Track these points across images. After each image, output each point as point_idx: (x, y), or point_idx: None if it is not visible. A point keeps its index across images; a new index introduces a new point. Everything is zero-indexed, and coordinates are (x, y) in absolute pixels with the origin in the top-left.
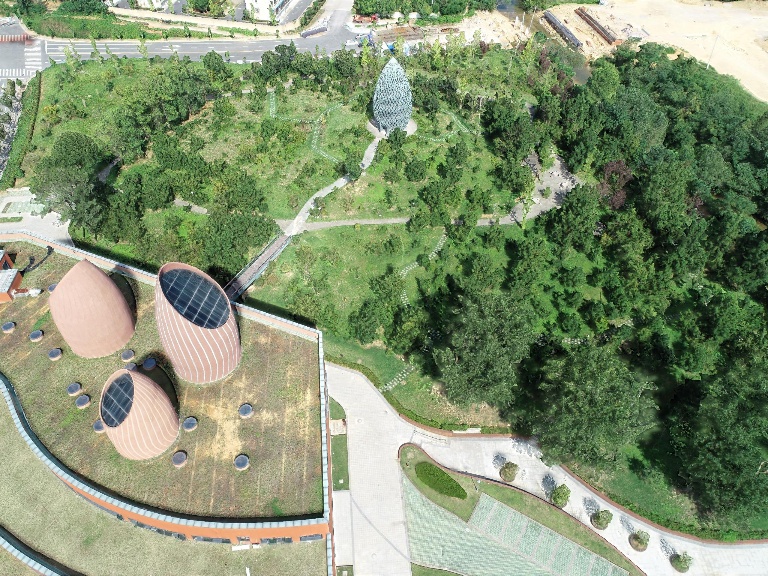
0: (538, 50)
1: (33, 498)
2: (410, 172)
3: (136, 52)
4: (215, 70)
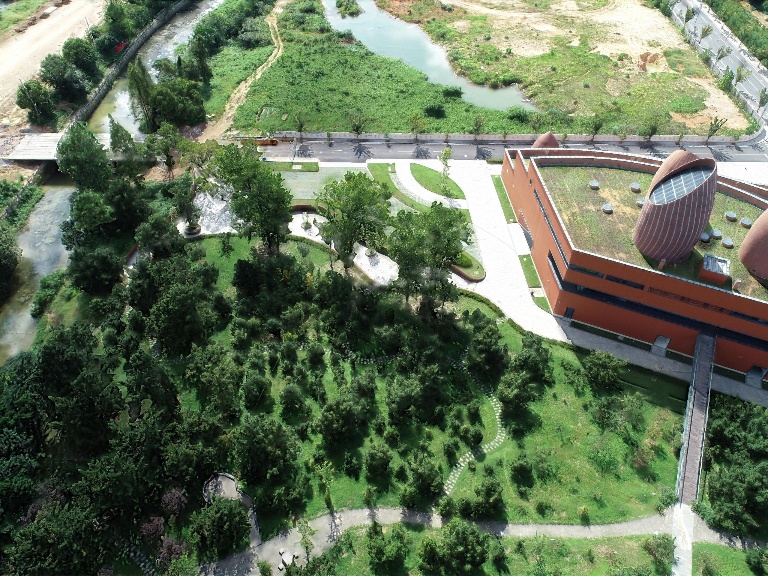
0: None
1: None
2: None
3: None
4: None
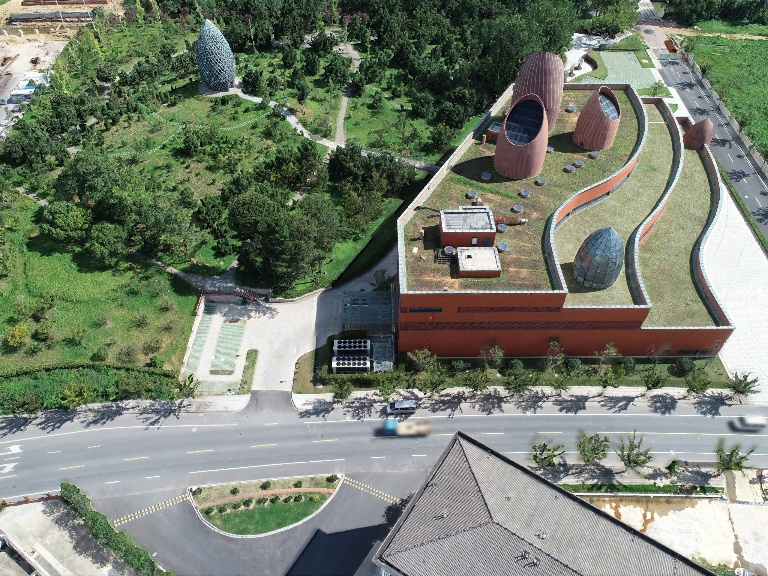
0: (117, 19)
1: (637, 193)
2: None
3: None
4: (5, 191)
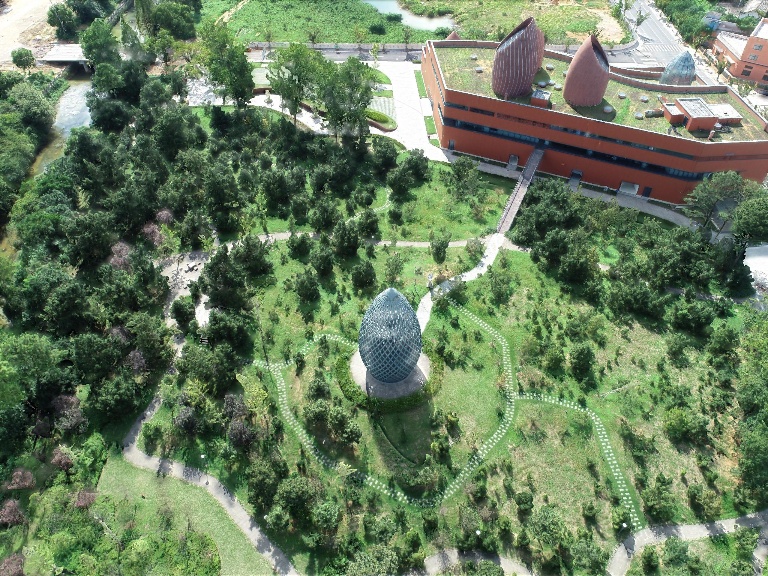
0: None
1: None
2: None
3: None
4: None
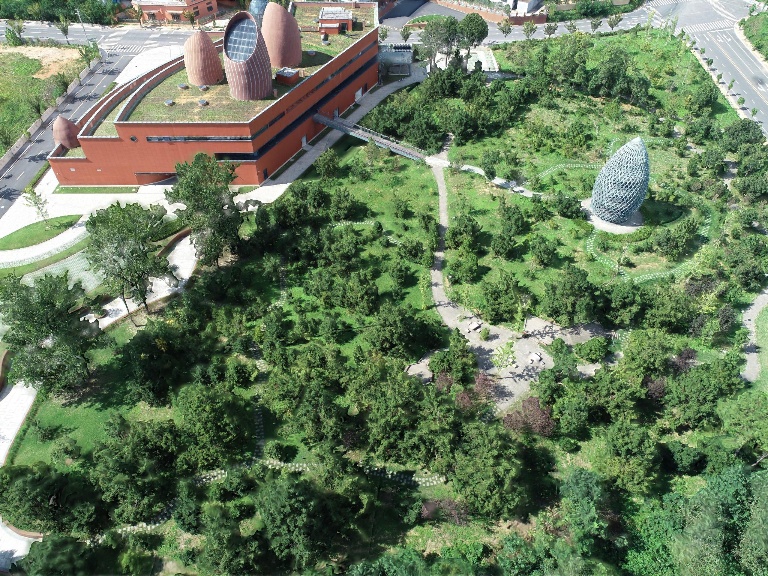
0: None
1: None
2: None
3: (741, 70)
4: None
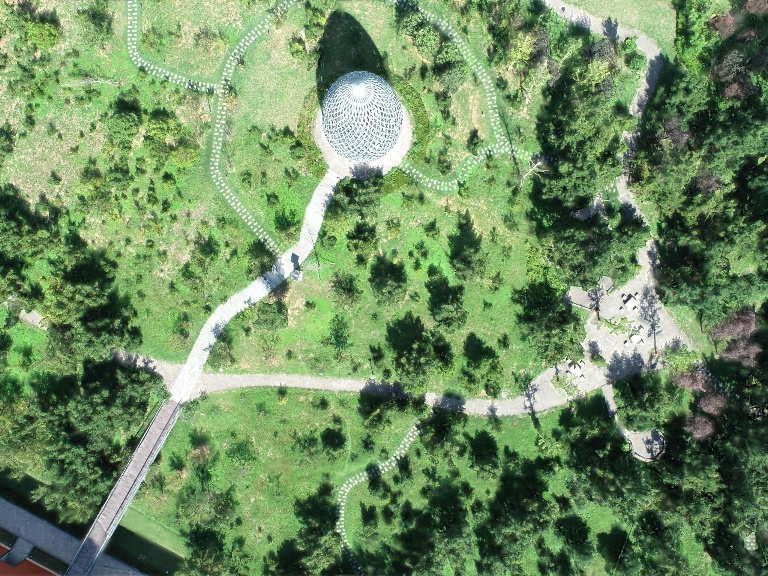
0: None
1: None
2: (377, 295)
3: None
4: None
